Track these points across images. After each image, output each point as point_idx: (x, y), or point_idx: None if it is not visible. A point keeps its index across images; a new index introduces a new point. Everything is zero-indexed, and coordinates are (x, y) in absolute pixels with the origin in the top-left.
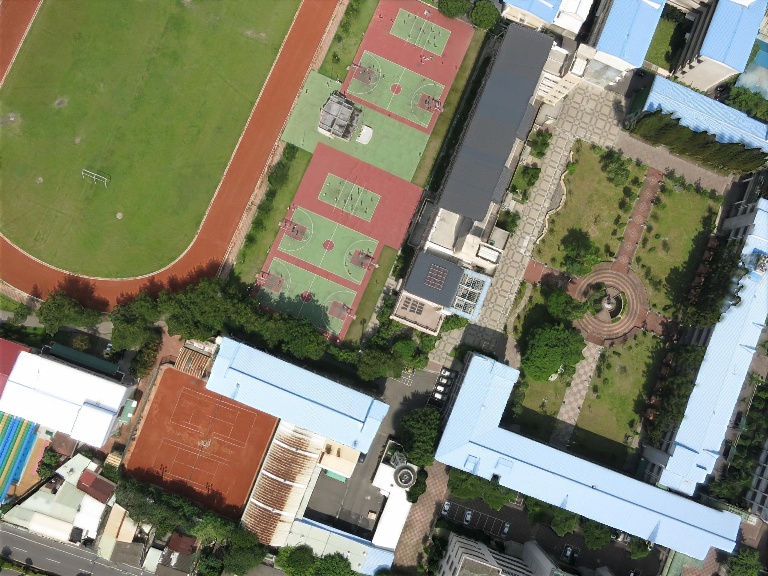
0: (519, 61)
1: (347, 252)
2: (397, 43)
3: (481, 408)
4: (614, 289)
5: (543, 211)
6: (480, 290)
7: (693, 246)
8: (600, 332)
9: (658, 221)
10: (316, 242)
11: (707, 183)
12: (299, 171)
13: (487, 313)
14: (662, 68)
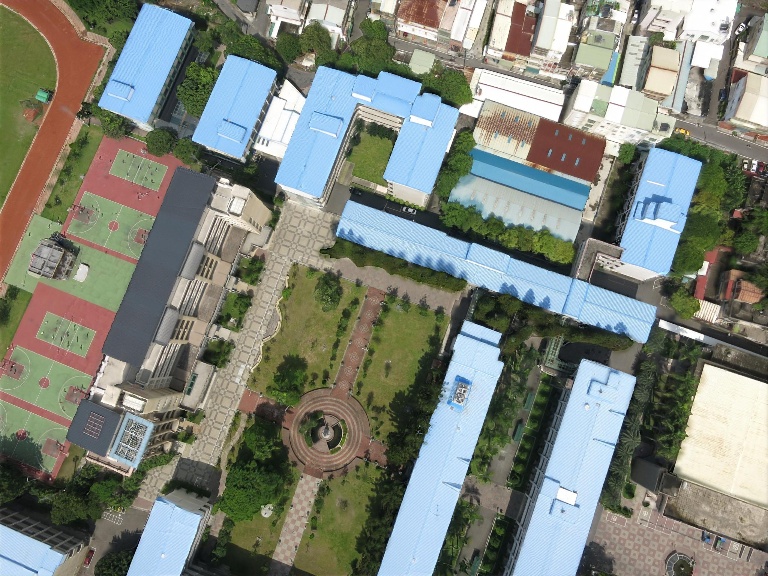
0: (183, 204)
1: (62, 389)
2: (116, 182)
3: (161, 556)
4: (333, 417)
5: (259, 338)
6: (143, 436)
7: (420, 368)
8: (319, 464)
9: (381, 343)
10: (33, 380)
11: (434, 300)
12: (19, 311)
13: (200, 446)
14: (381, 185)
